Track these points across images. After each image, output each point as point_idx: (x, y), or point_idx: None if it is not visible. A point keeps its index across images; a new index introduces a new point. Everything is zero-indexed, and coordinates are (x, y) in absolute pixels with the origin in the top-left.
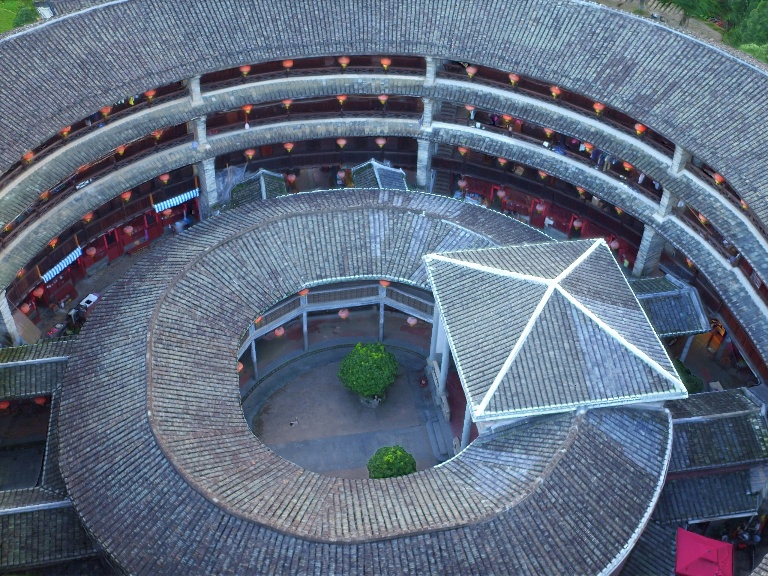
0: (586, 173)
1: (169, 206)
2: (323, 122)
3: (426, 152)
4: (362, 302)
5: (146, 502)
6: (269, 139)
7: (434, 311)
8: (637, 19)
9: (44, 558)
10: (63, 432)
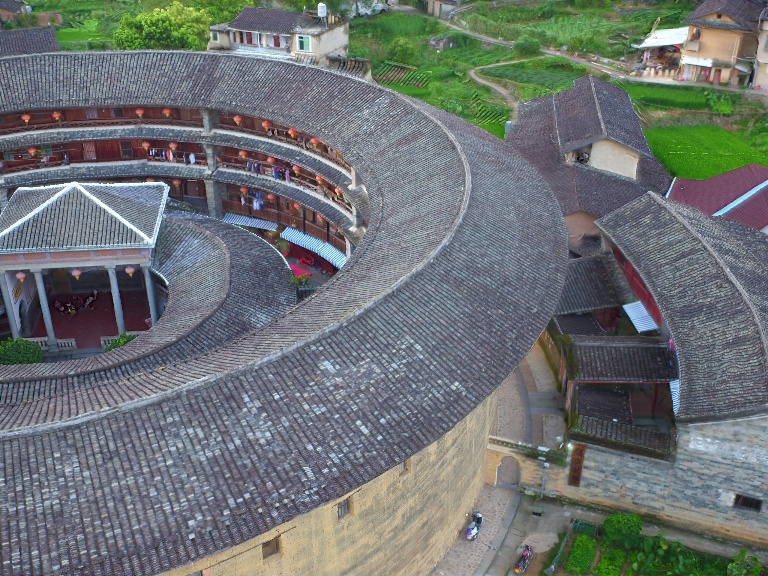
0: None
1: None
2: None
3: None
4: None
5: None
6: None
7: (5, 293)
8: None
9: None
10: None
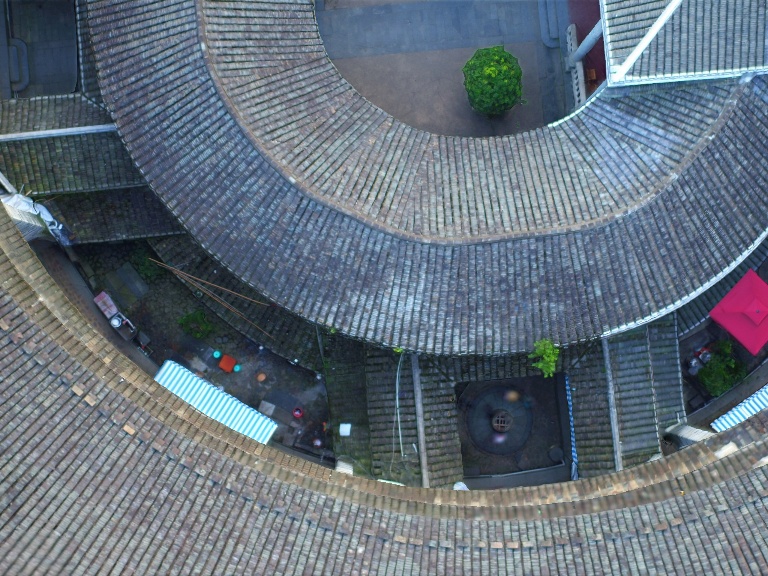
0: None
1: None
2: None
3: None
4: None
5: (211, 165)
6: None
7: None
8: None
9: (102, 185)
10: (98, 45)
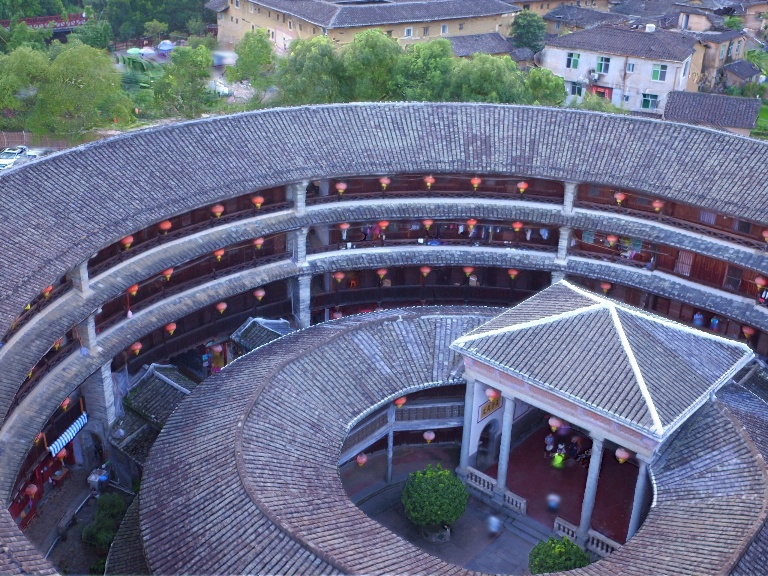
0: (471, 252)
1: (63, 444)
2: (199, 289)
3: (308, 289)
4: (376, 437)
5: None
6: (157, 322)
7: (467, 405)
8: (461, 105)
9: None
10: None
